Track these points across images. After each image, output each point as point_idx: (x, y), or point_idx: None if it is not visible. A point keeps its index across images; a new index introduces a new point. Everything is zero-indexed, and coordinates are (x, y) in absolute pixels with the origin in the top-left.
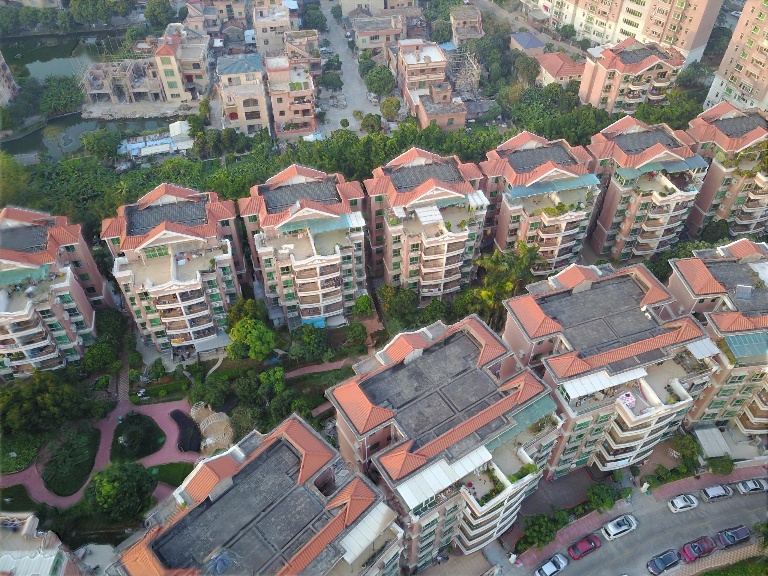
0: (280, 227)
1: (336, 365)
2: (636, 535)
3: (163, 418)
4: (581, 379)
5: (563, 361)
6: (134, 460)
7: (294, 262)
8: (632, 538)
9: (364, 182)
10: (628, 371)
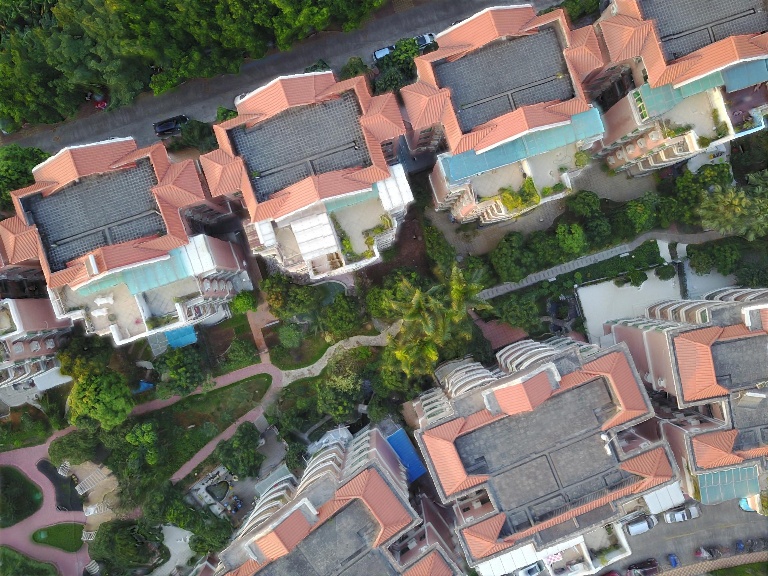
0: (79, 288)
1: (222, 381)
2: (546, 571)
3: (31, 469)
4: (500, 556)
5: (481, 542)
6: (17, 521)
7: (118, 343)
8: (541, 574)
9: (201, 161)
10: (560, 543)
